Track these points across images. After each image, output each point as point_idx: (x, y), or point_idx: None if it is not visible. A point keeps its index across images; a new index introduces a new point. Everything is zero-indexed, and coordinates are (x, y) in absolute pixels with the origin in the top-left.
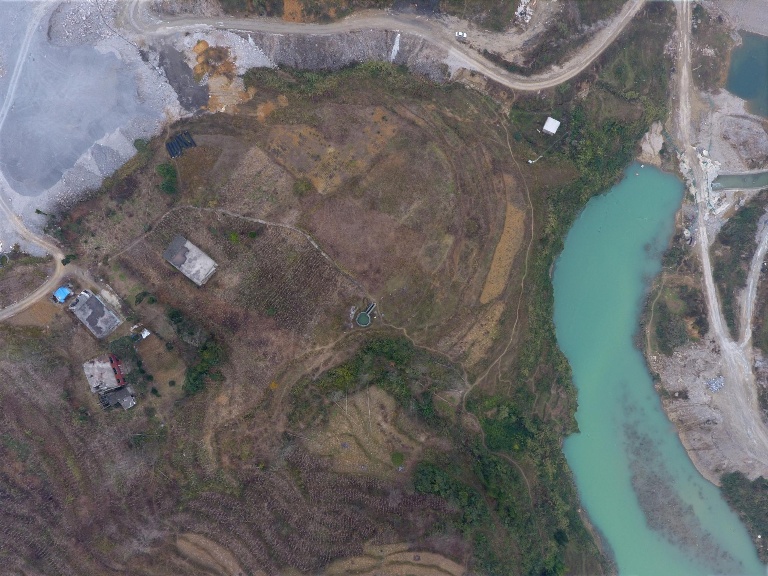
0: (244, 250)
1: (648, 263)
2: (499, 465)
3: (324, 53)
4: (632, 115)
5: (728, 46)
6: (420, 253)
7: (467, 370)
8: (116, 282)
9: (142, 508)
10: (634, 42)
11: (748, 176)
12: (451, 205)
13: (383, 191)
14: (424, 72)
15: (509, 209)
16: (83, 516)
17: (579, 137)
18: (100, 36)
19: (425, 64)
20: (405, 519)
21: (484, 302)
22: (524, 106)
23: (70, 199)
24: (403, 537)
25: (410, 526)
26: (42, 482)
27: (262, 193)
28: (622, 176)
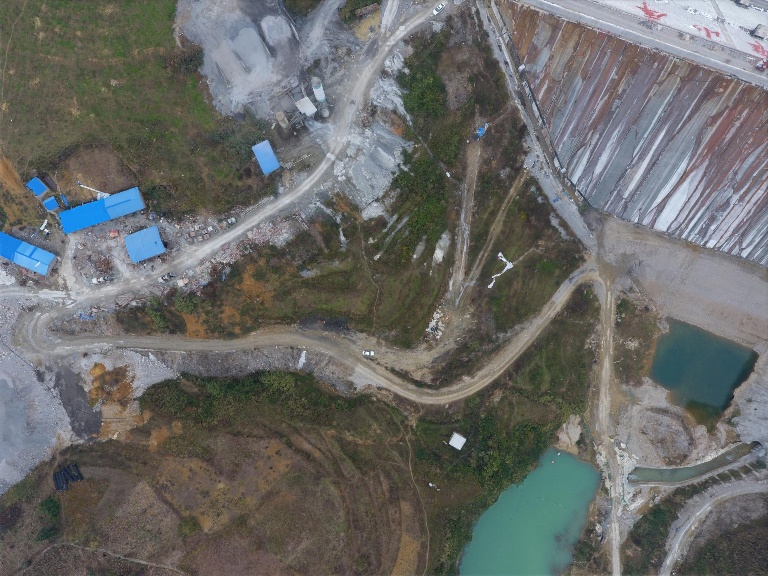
0: None
1: (558, 554)
2: None
3: (228, 366)
4: (546, 416)
5: (654, 334)
6: None
7: None
8: None
9: None
10: (553, 342)
11: (666, 470)
12: (340, 544)
13: (271, 530)
14: (330, 383)
15: (404, 539)
16: None
17: (487, 448)
18: None
19: (331, 377)
20: None
21: None
22: (431, 419)
23: None
24: None
25: None
26: None
27: (146, 532)
28: (537, 464)
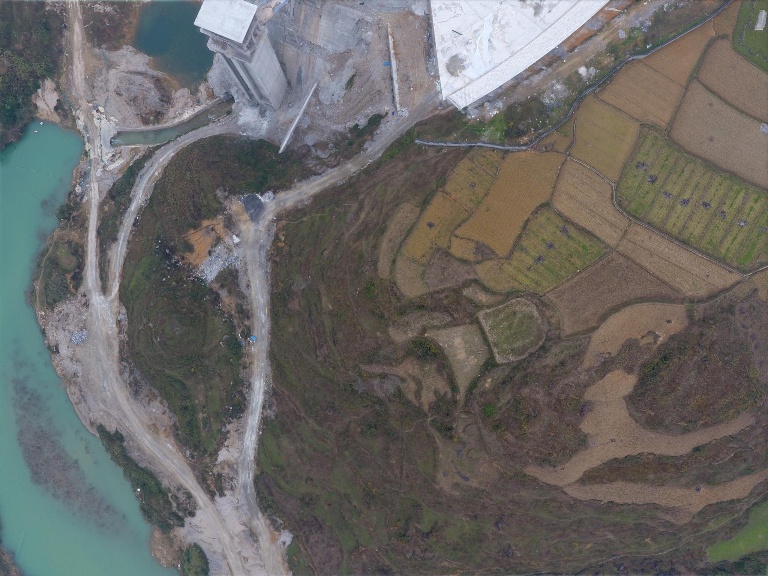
0: None
1: (44, 220)
2: None
3: None
4: None
5: (133, 3)
6: None
7: None
8: None
9: None
10: None
11: (149, 132)
12: None
13: None
14: None
15: None
16: None
17: None
18: None
19: None
20: None
21: None
22: None
23: None
24: None
25: None
26: None
27: None
28: (18, 133)
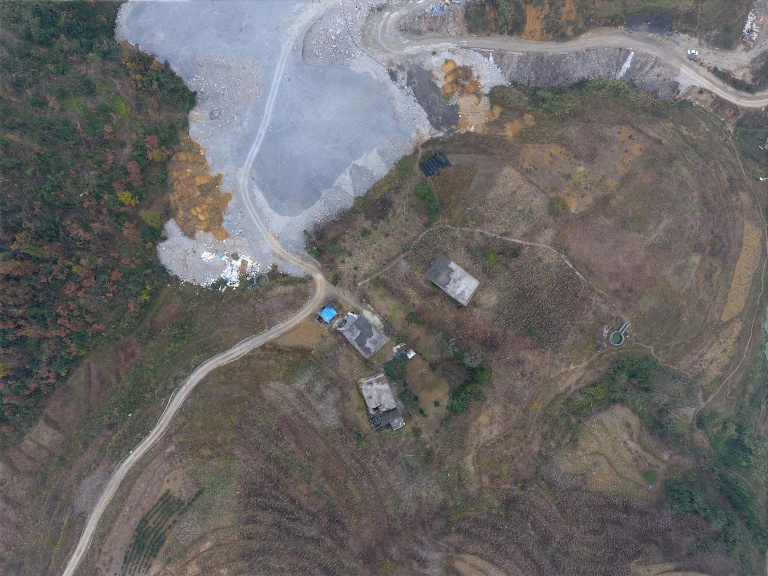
0: (502, 270)
1: None
2: (740, 483)
3: (558, 71)
4: None
5: None
6: (669, 272)
7: (704, 388)
8: (376, 302)
9: (416, 529)
10: None
11: None
12: (697, 224)
13: (633, 210)
14: (652, 89)
15: (746, 227)
16: (366, 538)
17: None
18: (349, 55)
19: (655, 82)
20: (666, 538)
21: (725, 320)
22: (748, 123)
23: (325, 219)
24: (668, 557)
25: (673, 545)
26: (328, 504)
27: (518, 213)
28: None
